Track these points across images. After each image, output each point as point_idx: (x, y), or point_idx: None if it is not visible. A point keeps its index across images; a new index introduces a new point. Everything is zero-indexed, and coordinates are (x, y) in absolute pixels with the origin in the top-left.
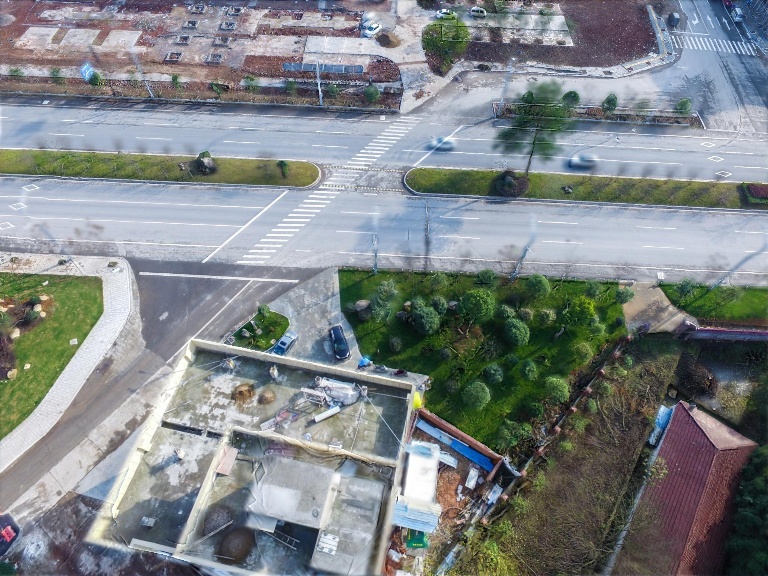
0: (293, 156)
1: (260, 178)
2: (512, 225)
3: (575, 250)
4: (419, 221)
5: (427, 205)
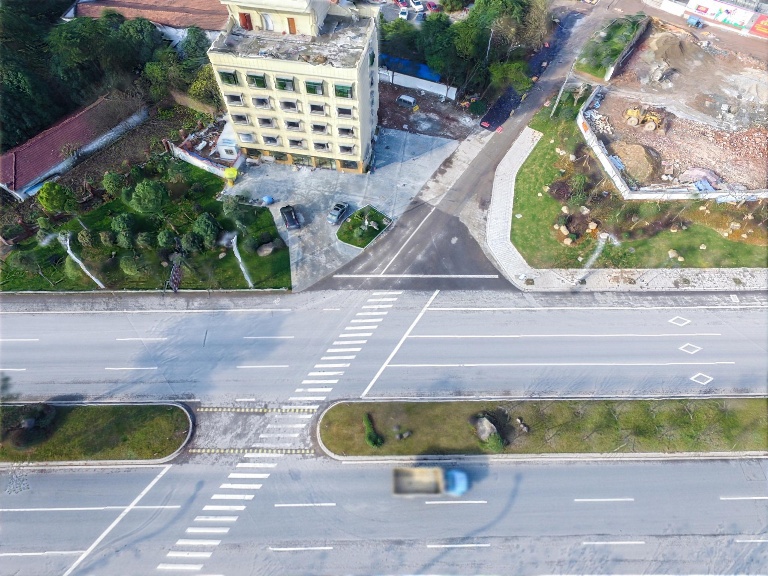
0: (364, 471)
1: (403, 410)
2: (65, 361)
3: (5, 330)
4: (187, 359)
5: (164, 291)
